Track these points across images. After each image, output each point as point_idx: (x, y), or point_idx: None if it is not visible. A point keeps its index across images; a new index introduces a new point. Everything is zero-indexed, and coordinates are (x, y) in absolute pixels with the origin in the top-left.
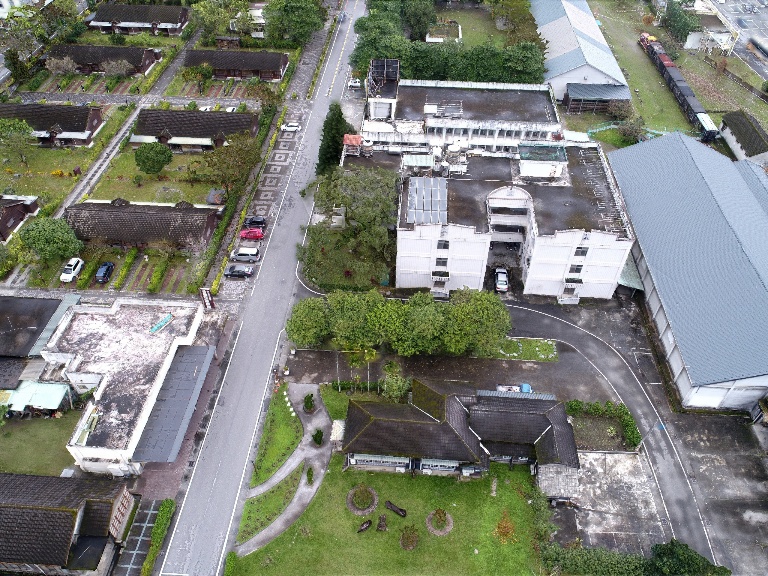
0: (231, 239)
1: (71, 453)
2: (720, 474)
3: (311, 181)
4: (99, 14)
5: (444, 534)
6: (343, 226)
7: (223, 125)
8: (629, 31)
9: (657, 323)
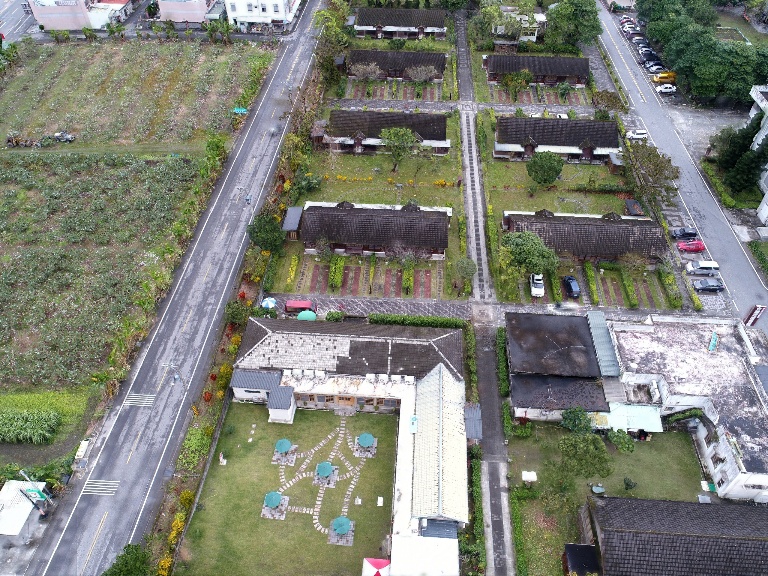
0: (669, 251)
1: (734, 480)
2: None
3: (701, 190)
4: (361, 18)
5: None
6: None
7: (588, 133)
8: None
9: None
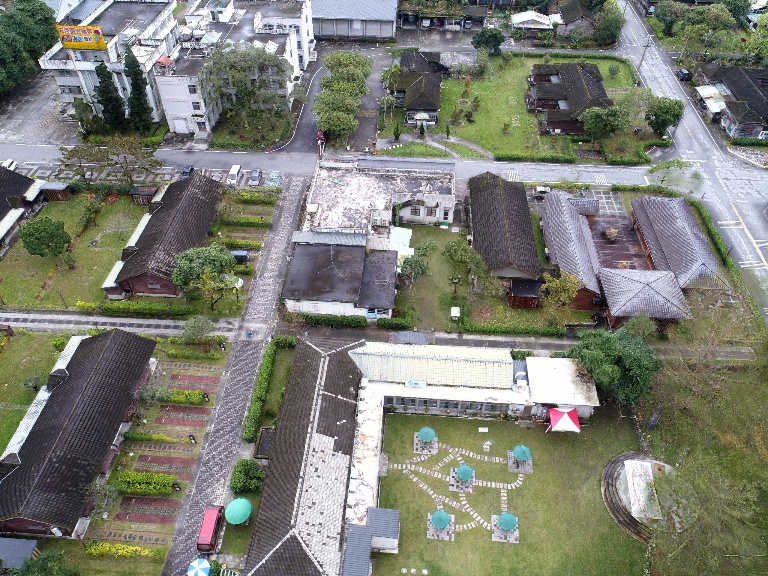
0: None
1: None
2: (429, 39)
3: None
4: None
5: (470, 101)
6: (210, 131)
7: None
8: None
9: (340, 34)
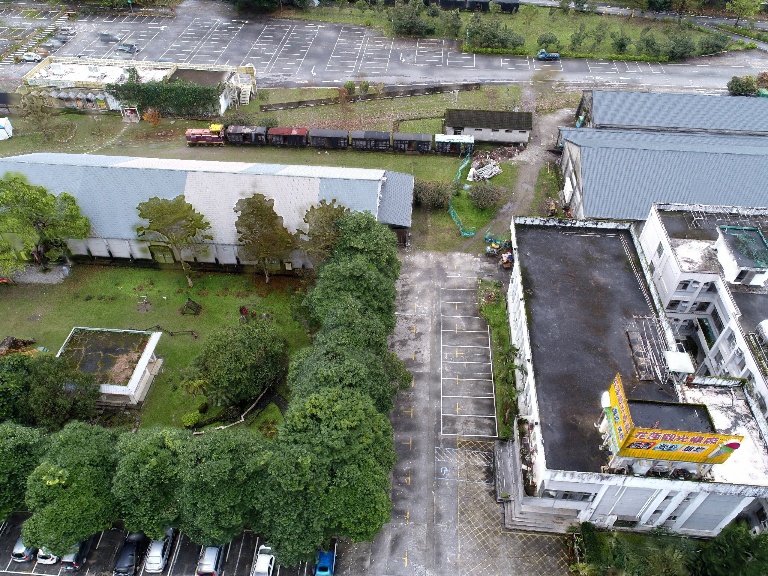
0: None
1: None
2: None
3: None
4: None
5: None
6: None
7: None
8: (144, 145)
9: None
